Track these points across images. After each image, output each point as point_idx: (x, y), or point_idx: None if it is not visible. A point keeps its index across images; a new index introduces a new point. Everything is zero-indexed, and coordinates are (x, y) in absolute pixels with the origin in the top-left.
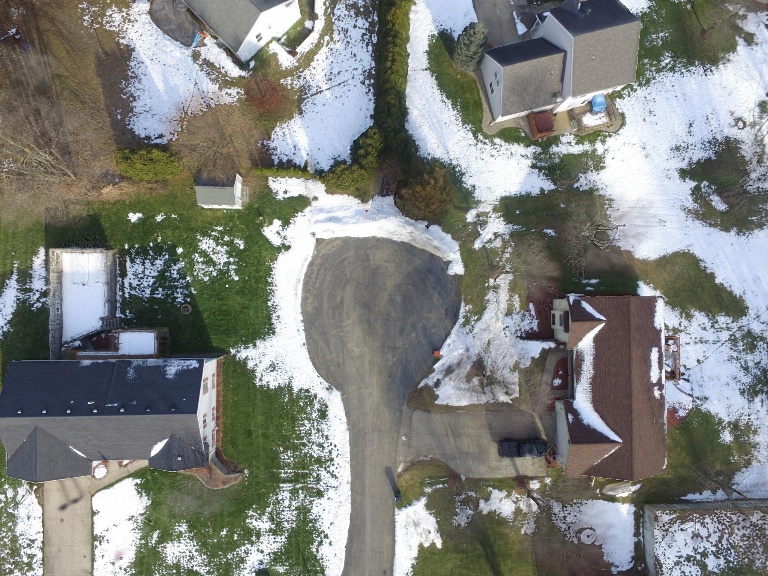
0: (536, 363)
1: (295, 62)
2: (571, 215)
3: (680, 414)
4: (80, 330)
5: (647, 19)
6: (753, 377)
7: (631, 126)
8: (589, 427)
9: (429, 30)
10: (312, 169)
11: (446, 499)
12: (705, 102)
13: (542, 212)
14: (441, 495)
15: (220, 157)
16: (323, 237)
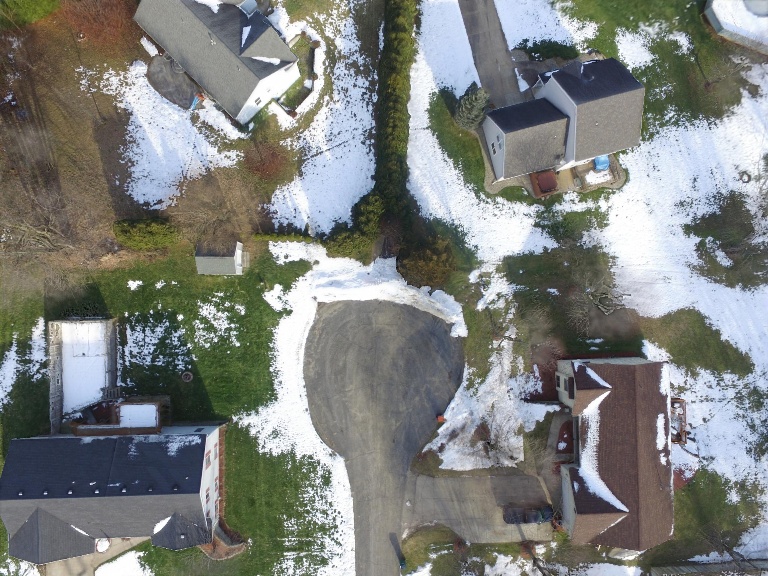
0: (541, 427)
1: (295, 123)
2: (575, 273)
3: (686, 476)
4: (81, 401)
5: (650, 73)
6: (759, 435)
7: (635, 182)
8: (595, 496)
9: (430, 88)
10: (313, 232)
11: (451, 565)
12: (709, 156)
13: (545, 271)
14: (446, 561)
15: (220, 224)
16: (325, 301)
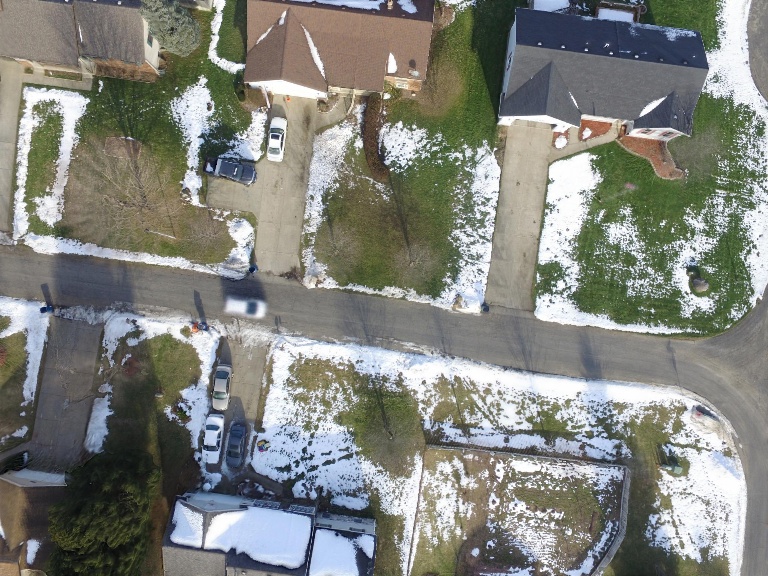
0: None
1: None
2: None
3: None
4: (549, 9)
5: None
6: None
7: None
8: None
9: None
10: None
11: None
12: None
13: None
14: None
15: None
16: None
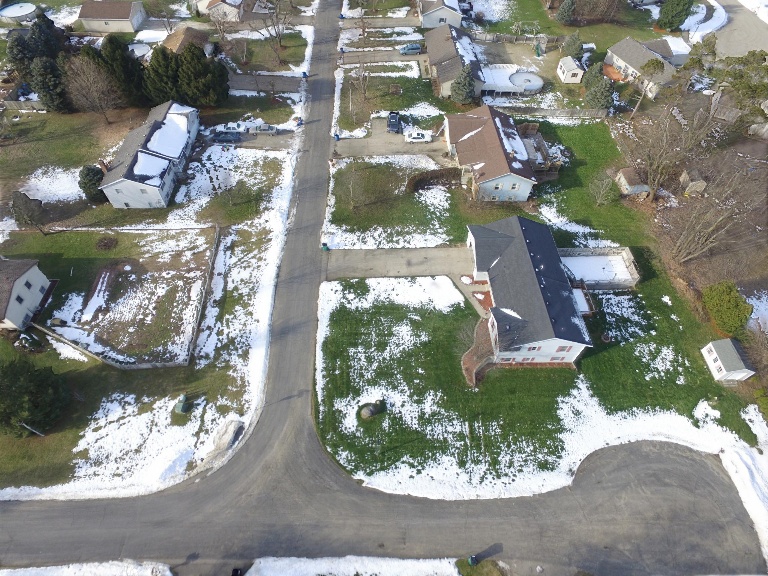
0: None
1: None
2: None
3: None
4: (568, 267)
5: None
6: None
7: None
8: None
9: None
10: None
11: None
12: None
13: None
14: None
15: None
16: (723, 462)
